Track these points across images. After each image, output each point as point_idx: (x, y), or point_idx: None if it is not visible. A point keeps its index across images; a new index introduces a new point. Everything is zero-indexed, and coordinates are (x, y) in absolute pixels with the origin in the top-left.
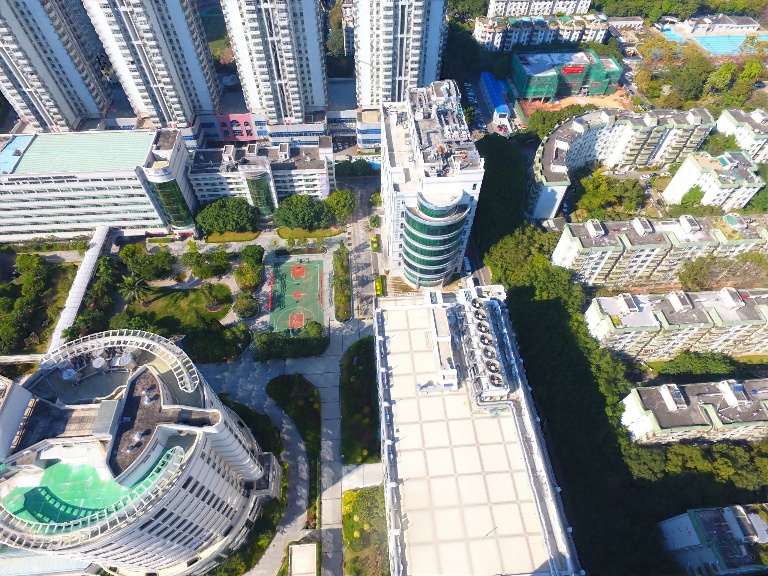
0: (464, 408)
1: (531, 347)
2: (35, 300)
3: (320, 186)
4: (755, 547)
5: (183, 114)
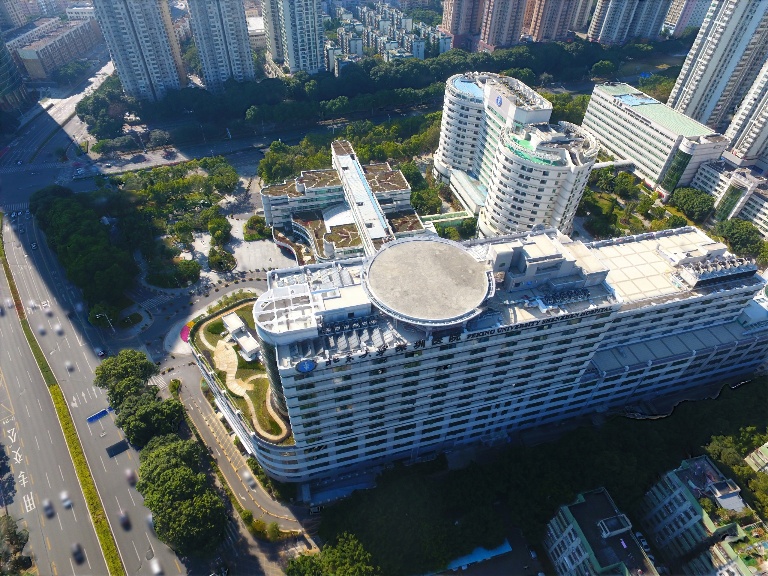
0: (664, 270)
1: (763, 380)
2: None
3: None
4: (710, 498)
5: (749, 148)
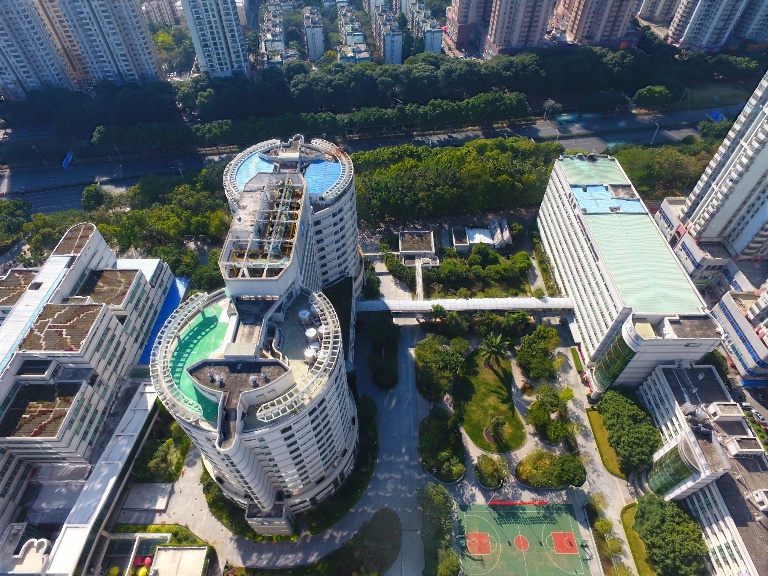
0: None
1: None
2: (480, 277)
3: (732, 575)
4: None
5: None
